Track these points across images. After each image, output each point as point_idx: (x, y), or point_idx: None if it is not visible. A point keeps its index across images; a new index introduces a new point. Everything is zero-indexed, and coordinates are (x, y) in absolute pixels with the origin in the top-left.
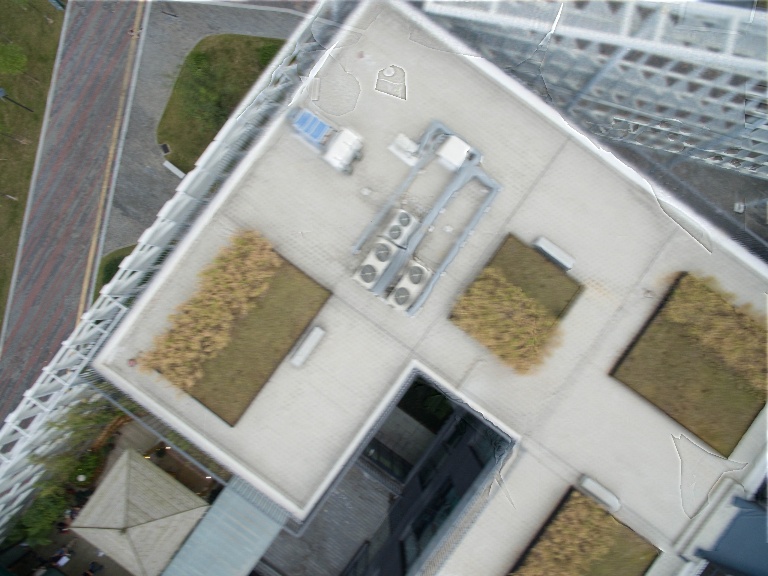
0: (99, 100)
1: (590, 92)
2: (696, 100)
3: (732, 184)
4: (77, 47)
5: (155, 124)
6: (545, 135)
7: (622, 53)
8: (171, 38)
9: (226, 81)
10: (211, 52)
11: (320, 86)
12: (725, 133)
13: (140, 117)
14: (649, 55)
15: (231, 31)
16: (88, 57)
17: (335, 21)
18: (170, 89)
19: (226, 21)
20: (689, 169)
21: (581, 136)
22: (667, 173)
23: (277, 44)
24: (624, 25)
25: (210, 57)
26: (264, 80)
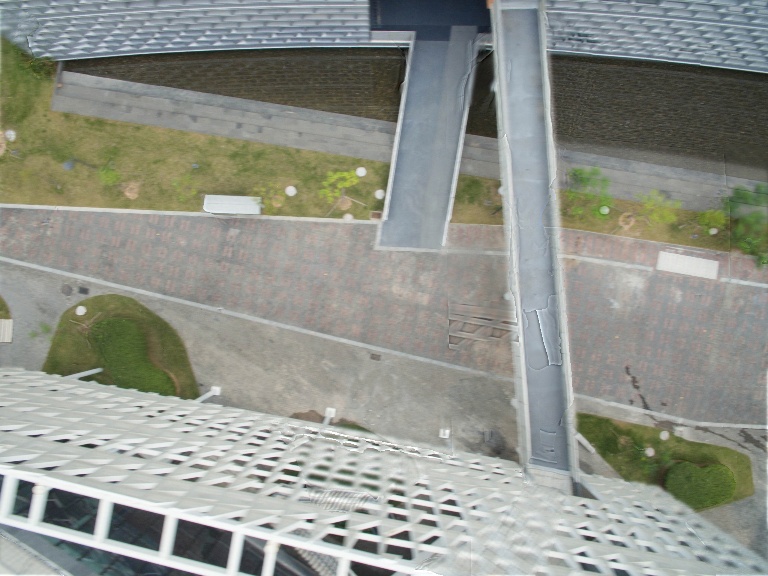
0: None
1: (288, 320)
2: (397, 323)
3: (438, 408)
4: None
5: None
6: (5, 555)
7: (319, 278)
8: None
9: None
10: None
11: (13, 328)
12: (429, 356)
13: None
14: (347, 279)
15: None
16: None
17: (25, 261)
18: None
19: None
20: (392, 395)
21: (39, 557)
22: (369, 400)
23: None
24: (320, 249)
25: None
26: None
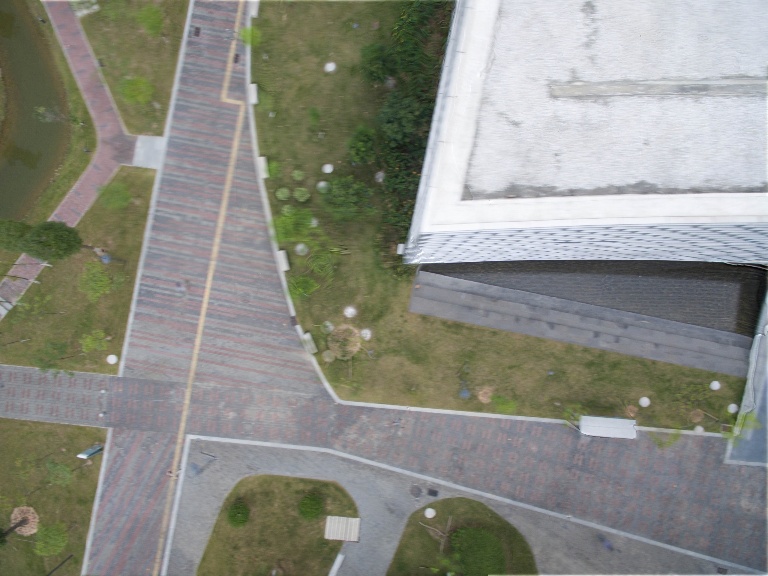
0: (138, 542)
1: (636, 531)
2: (745, 538)
3: None
4: (116, 488)
5: (194, 567)
6: None
7: (668, 490)
8: (210, 479)
9: (266, 526)
10: (250, 495)
11: (360, 527)
12: None
13: (179, 560)
14: (696, 492)
15: (270, 472)
16: (127, 499)
17: (375, 461)
18: (209, 531)
19: (265, 461)
20: None
21: None
22: None
23: (317, 486)
24: (670, 461)
25: (249, 501)
26: (304, 525)
